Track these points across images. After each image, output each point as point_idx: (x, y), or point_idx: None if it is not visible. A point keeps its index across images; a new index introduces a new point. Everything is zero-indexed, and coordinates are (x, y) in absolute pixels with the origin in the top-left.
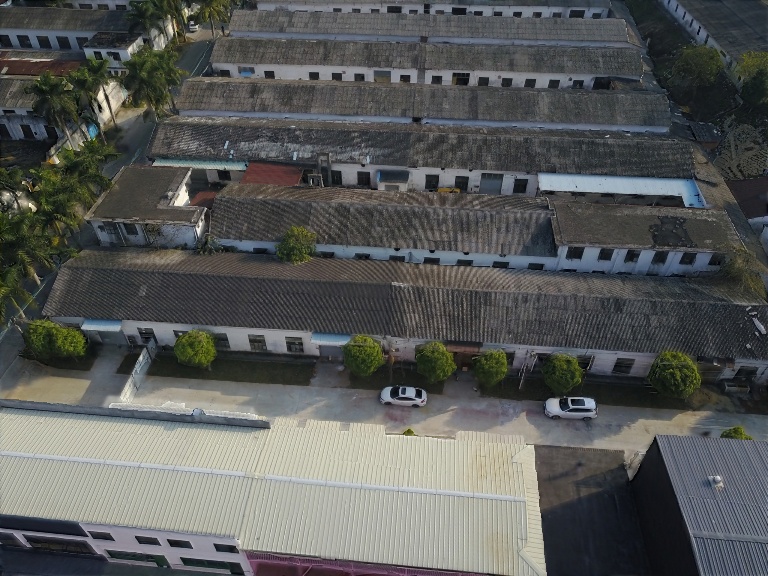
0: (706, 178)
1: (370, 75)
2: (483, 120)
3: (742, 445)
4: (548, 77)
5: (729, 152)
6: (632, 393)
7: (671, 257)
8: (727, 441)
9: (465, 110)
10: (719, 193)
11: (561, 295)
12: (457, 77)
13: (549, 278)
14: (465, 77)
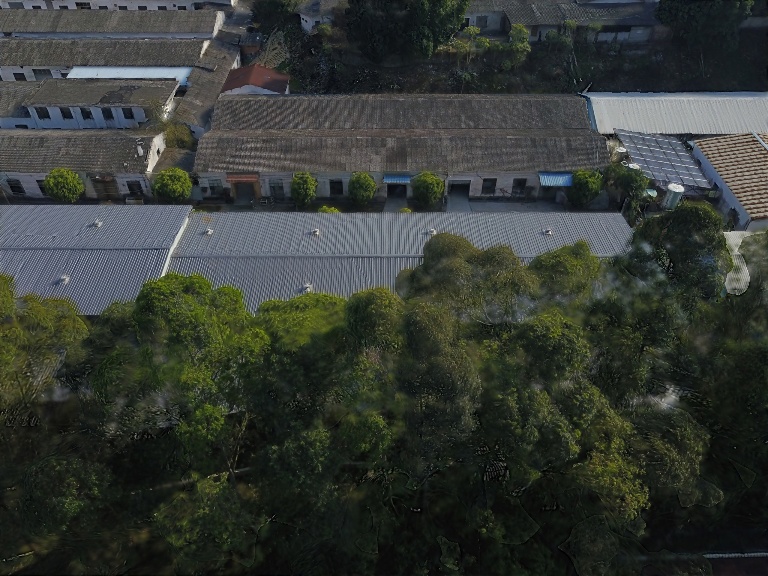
0: (203, 65)
1: (6, 7)
2: (61, 33)
3: (27, 207)
4: (155, 4)
5: (264, 53)
6: None
7: (115, 113)
8: (19, 206)
9: (47, 25)
10: (210, 76)
11: (1, 137)
12: (81, 6)
13: (14, 131)
14: (87, 6)
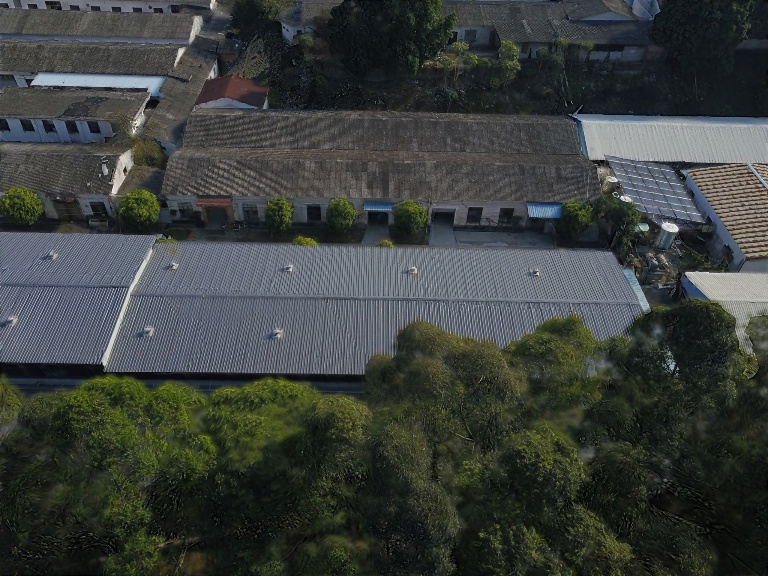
0: (177, 75)
1: None
2: (27, 34)
3: None
4: (130, 5)
5: (243, 62)
6: (12, 229)
7: (80, 126)
8: None
9: (13, 26)
10: (184, 86)
11: None
12: (51, 5)
13: None
14: (58, 5)
